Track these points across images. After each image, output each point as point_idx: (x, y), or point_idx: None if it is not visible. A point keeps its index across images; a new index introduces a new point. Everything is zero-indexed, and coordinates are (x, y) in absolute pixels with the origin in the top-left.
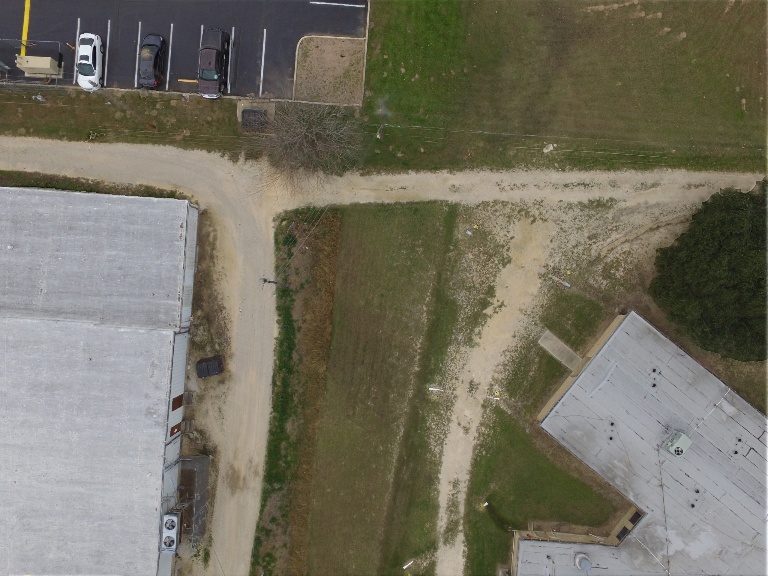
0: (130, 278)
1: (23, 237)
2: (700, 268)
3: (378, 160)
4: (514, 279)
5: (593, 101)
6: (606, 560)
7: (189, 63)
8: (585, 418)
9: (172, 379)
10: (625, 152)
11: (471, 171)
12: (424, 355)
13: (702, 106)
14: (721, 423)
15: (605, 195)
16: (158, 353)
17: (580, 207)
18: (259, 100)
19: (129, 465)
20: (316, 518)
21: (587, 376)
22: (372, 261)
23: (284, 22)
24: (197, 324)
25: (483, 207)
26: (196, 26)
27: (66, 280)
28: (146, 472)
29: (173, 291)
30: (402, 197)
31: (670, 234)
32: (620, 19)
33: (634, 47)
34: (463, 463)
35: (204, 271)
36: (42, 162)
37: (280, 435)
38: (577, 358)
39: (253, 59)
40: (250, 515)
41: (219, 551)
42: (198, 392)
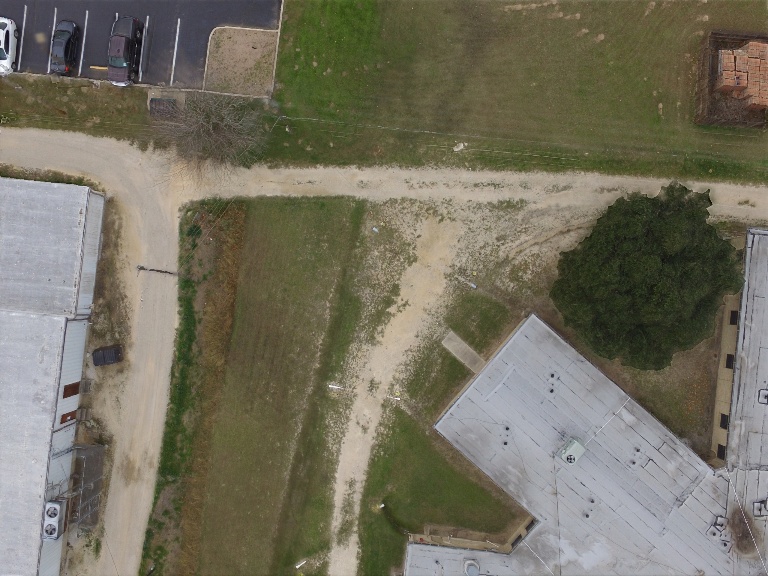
0: (27, 262)
1: None
2: (592, 272)
3: (286, 153)
4: (419, 278)
5: (506, 101)
6: (497, 568)
7: (101, 50)
8: (480, 422)
9: (63, 366)
10: (537, 153)
11: (380, 167)
12: (325, 352)
13: (617, 109)
14: (620, 432)
15: (515, 196)
16: (48, 339)
17: (489, 207)
18: (169, 89)
19: (15, 450)
20: (210, 513)
21: (484, 379)
22: (276, 255)
23: (198, 12)
24: (98, 312)
25: (390, 204)
26: (110, 13)
27: None
28: (31, 458)
29: (69, 277)
30: (309, 191)
31: (580, 238)
32: (537, 19)
33: (550, 48)
34: (360, 463)
35: (108, 259)
36: None
37: (176, 427)
38: (480, 361)
39: (165, 48)
40: (143, 507)
41: (111, 542)
42: (96, 380)
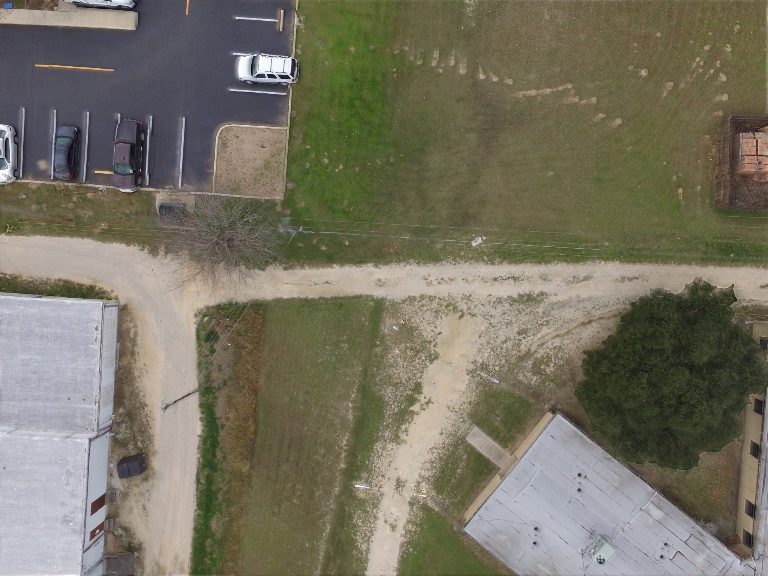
0: (45, 383)
1: None
2: (619, 383)
3: (302, 254)
4: (441, 375)
5: (524, 191)
6: None
7: (105, 154)
8: (509, 522)
9: (89, 485)
10: (556, 245)
11: (397, 265)
12: (350, 452)
13: (637, 196)
14: (647, 527)
15: (535, 289)
16: (73, 461)
17: (510, 301)
18: (178, 193)
19: (46, 573)
20: None
21: (511, 480)
22: (296, 357)
23: (203, 110)
24: (119, 422)
25: (410, 302)
26: (112, 115)
27: None
28: None
29: (89, 395)
30: (326, 292)
31: (602, 328)
32: (553, 105)
33: (567, 134)
34: (389, 560)
35: (125, 368)
36: None
37: (205, 533)
38: (505, 455)
39: (172, 149)
40: None
41: None
42: (122, 490)
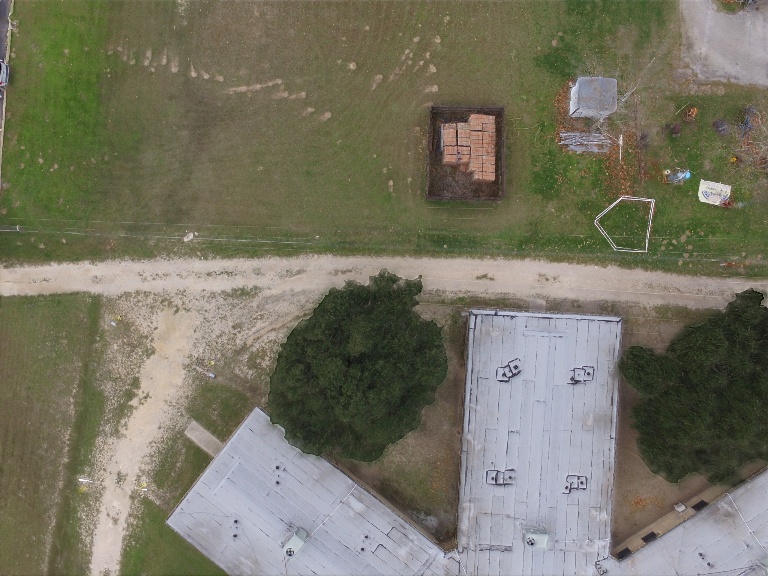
0: None
1: None
2: (280, 375)
3: (20, 252)
4: (159, 370)
5: (235, 187)
6: None
7: None
8: (210, 515)
9: None
10: (267, 239)
11: (113, 262)
12: (73, 446)
13: (347, 189)
14: (348, 519)
15: (249, 283)
16: None
17: (223, 296)
18: None
19: None
20: None
21: (211, 473)
22: (18, 354)
23: None
24: None
25: (125, 298)
26: None
27: None
28: None
29: None
30: (45, 289)
31: None
32: (263, 100)
33: (276, 129)
34: (113, 553)
35: None
36: None
37: None
38: None
39: None
40: None
41: None
42: None
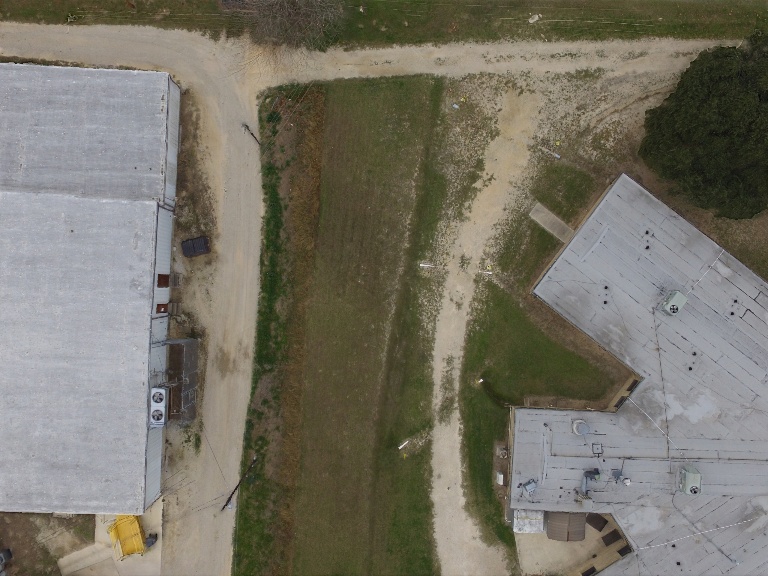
0: (111, 152)
1: (1, 112)
2: (690, 113)
3: (362, 34)
4: (503, 151)
5: None
6: (604, 426)
7: None
8: (578, 283)
9: (157, 252)
10: (611, 21)
11: (456, 44)
12: (414, 231)
13: None
14: (716, 285)
15: (593, 65)
16: (141, 224)
17: (568, 77)
18: None
19: (114, 339)
20: (308, 399)
21: (579, 240)
22: (358, 137)
23: None
24: (182, 205)
25: (469, 79)
26: None
27: (46, 155)
28: (132, 345)
29: (156, 164)
30: (387, 71)
31: (659, 103)
32: None
33: None
34: (456, 339)
35: (188, 151)
36: (20, 46)
37: (269, 315)
38: (569, 230)
39: None
40: (241, 398)
41: (210, 436)
42: (185, 274)
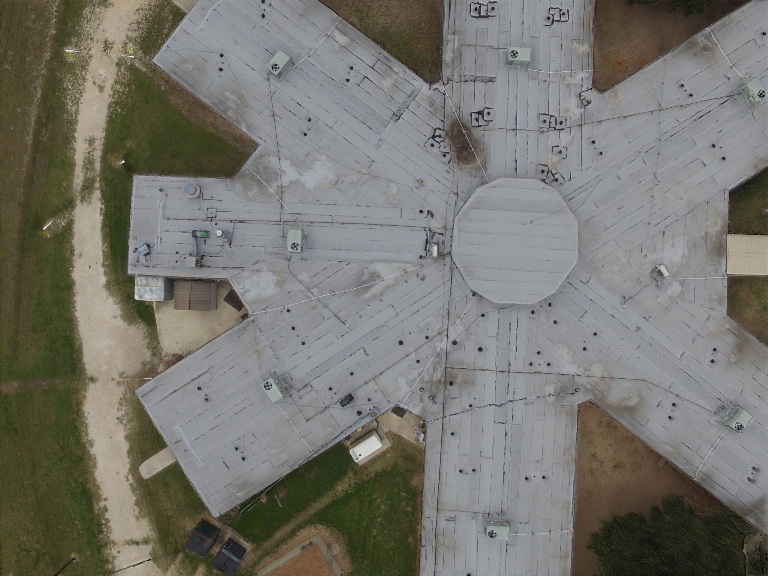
0: None
1: None
2: None
3: None
4: None
5: None
6: (220, 193)
7: None
8: (196, 51)
9: None
10: None
11: None
12: (61, 18)
13: None
14: (334, 53)
15: None
16: None
17: None
18: None
19: None
20: None
21: (197, 10)
22: None
23: None
24: None
25: None
26: None
27: None
28: None
29: None
30: None
31: None
32: None
33: None
34: (98, 121)
35: None
36: None
37: None
38: None
39: None
40: None
41: None
42: None
